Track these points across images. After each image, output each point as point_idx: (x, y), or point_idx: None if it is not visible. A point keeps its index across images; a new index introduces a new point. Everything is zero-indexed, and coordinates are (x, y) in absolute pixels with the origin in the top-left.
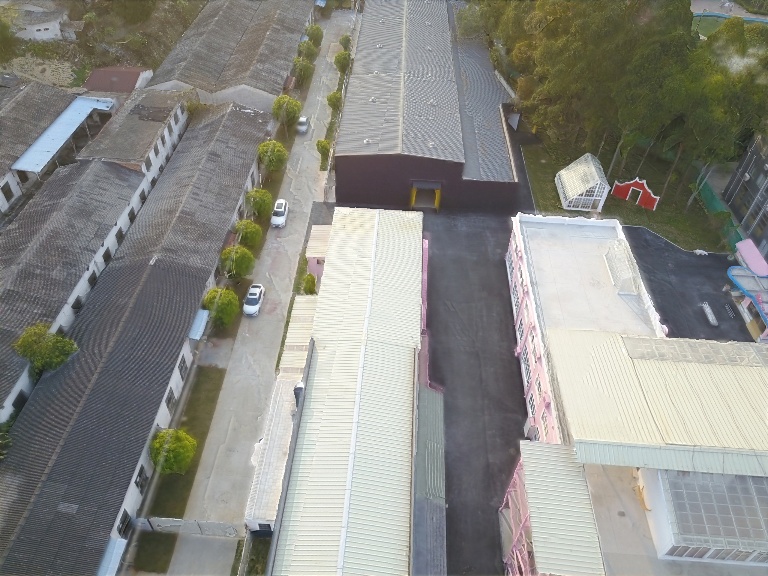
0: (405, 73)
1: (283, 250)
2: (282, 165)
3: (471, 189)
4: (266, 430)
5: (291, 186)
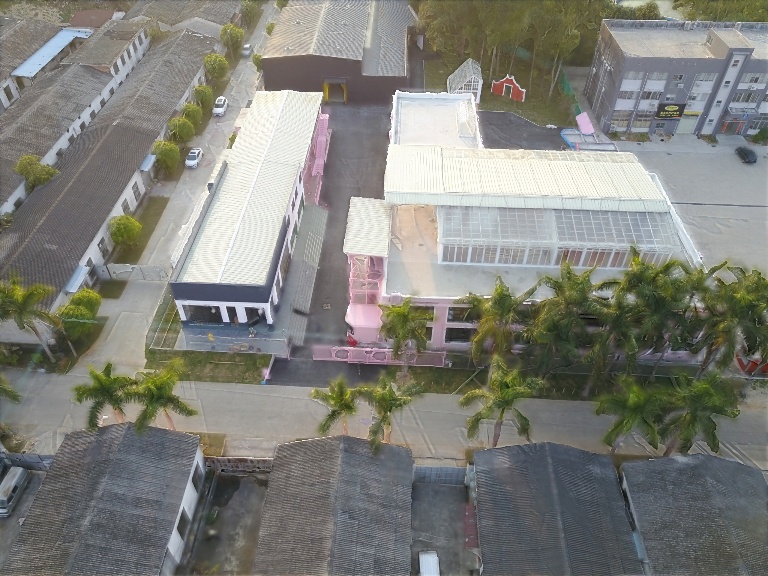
0: (328, 4)
1: (221, 130)
2: (224, 73)
3: (370, 84)
4: (190, 218)
5: (232, 91)
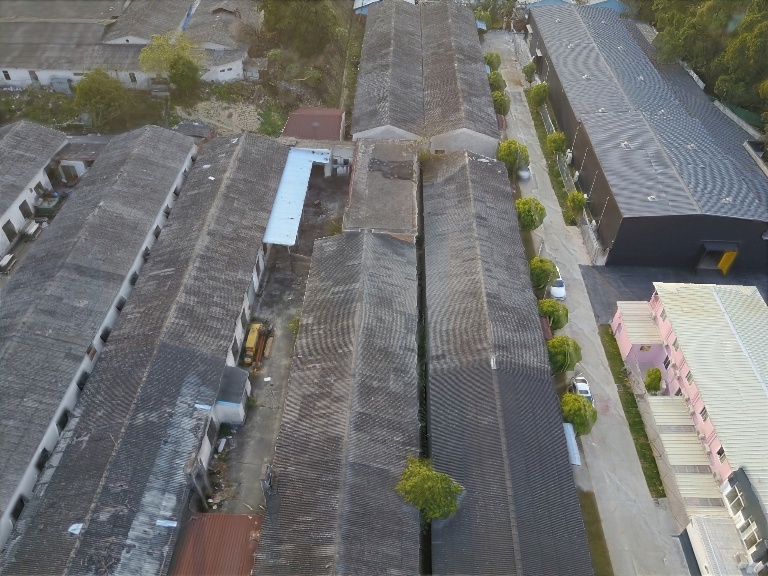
0: None
1: (578, 329)
2: (540, 224)
3: (767, 249)
4: None
5: (545, 246)
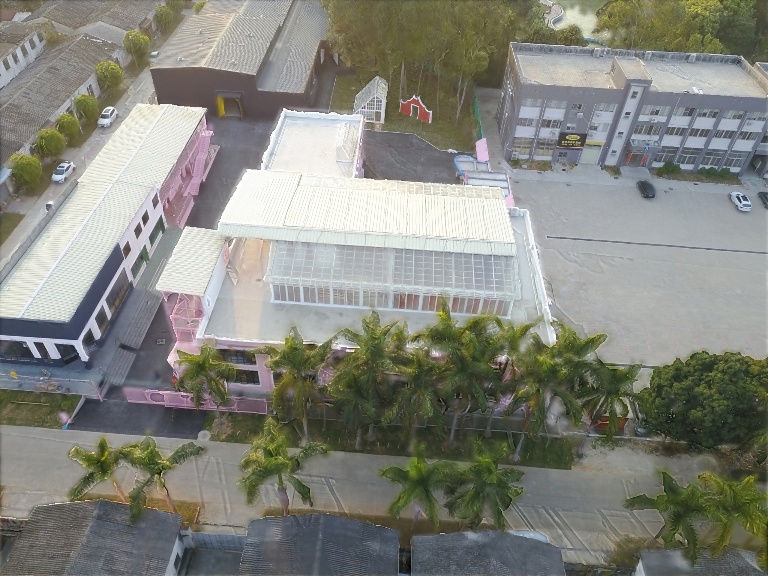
0: None
1: (102, 142)
2: (117, 81)
3: (267, 99)
4: None
5: (127, 100)
